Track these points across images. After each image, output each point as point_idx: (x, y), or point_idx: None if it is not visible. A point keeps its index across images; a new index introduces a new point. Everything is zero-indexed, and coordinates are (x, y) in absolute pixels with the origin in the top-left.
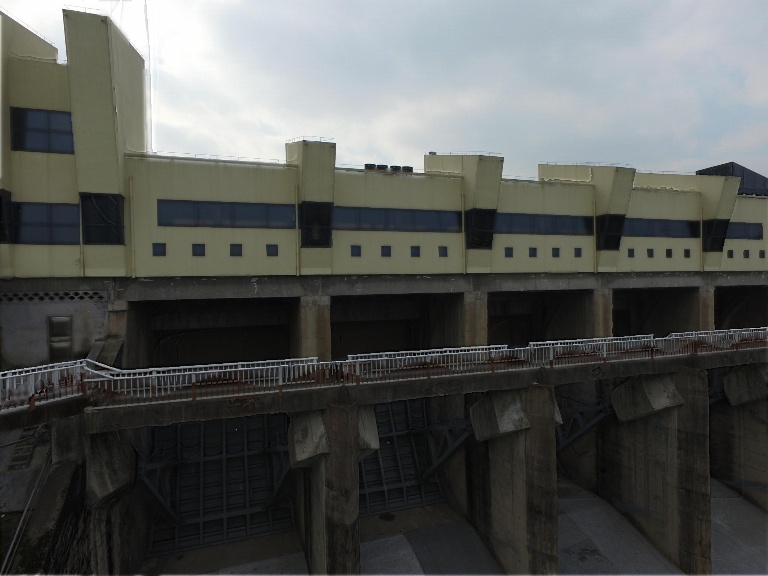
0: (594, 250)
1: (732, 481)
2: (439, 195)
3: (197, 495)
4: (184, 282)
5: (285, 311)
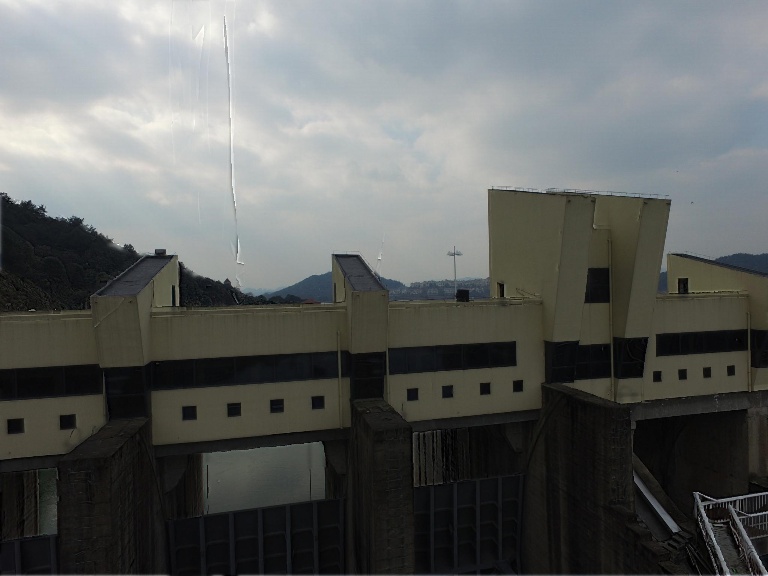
0: None
1: None
2: None
3: None
4: (670, 402)
5: None
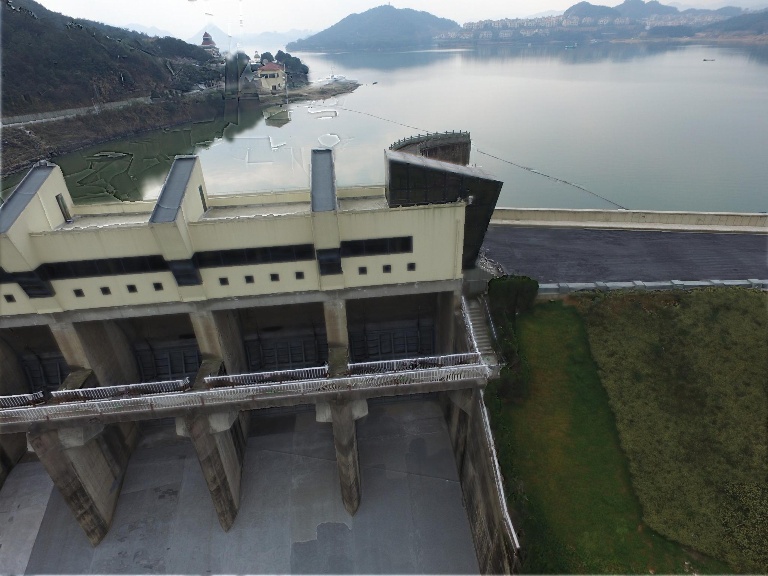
0: (176, 284)
1: None
2: None
3: None
4: None
5: None
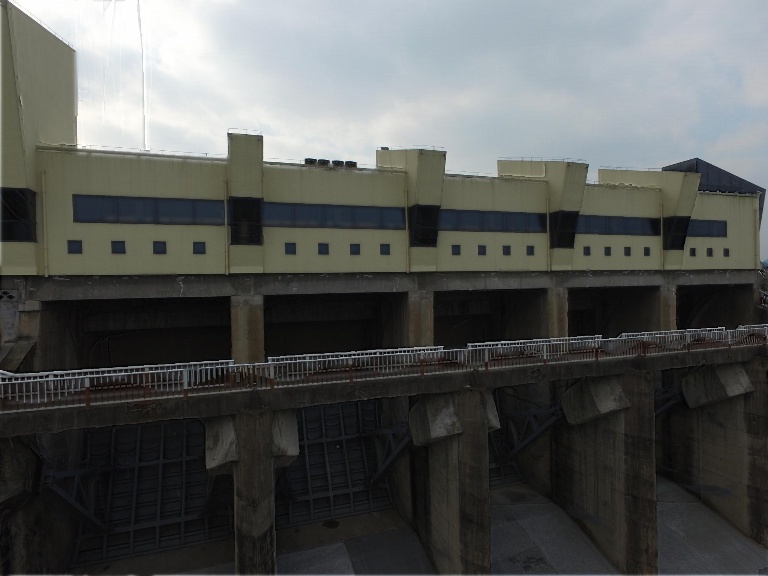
0: (547, 248)
1: (691, 485)
2: (381, 191)
3: (130, 502)
4: (103, 281)
5: (228, 311)
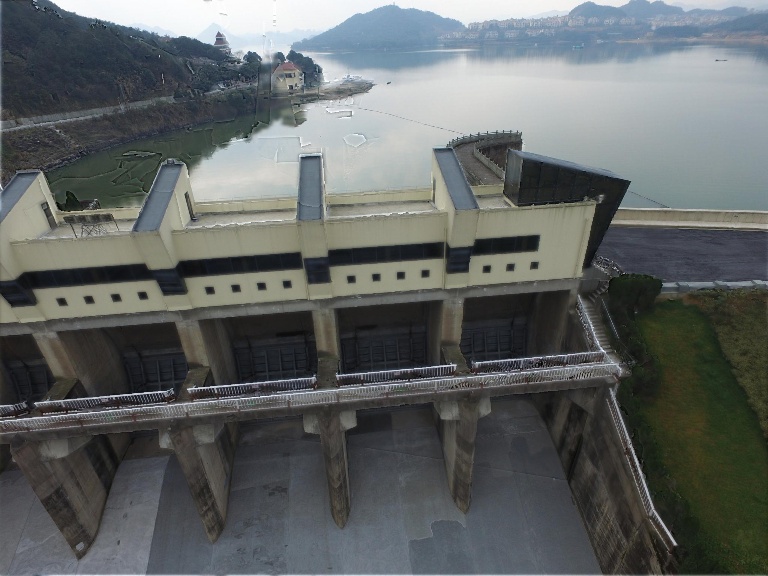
0: (305, 282)
1: (442, 447)
2: (125, 252)
3: None
4: None
5: None
